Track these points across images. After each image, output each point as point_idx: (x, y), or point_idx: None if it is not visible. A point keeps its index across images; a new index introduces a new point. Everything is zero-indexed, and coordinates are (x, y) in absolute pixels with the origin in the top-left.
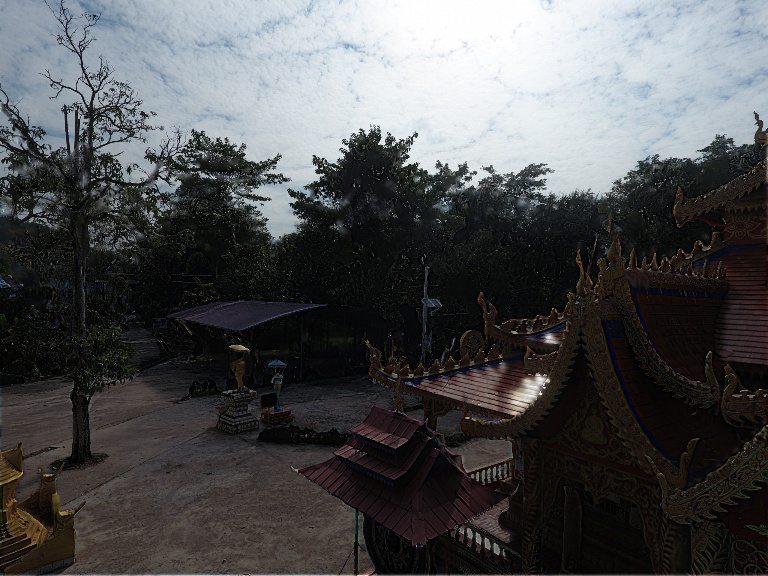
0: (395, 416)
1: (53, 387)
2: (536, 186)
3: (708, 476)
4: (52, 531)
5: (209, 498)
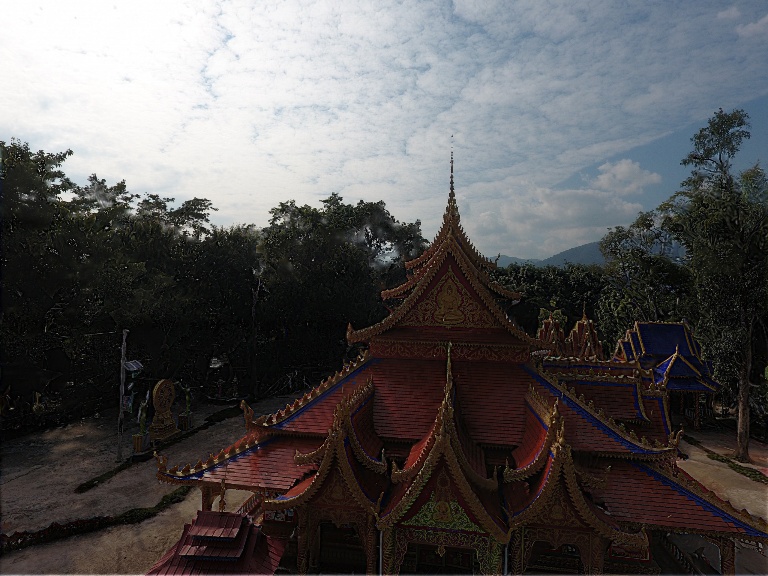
0: (222, 515)
1: None
2: (199, 218)
3: (392, 511)
4: None
5: None
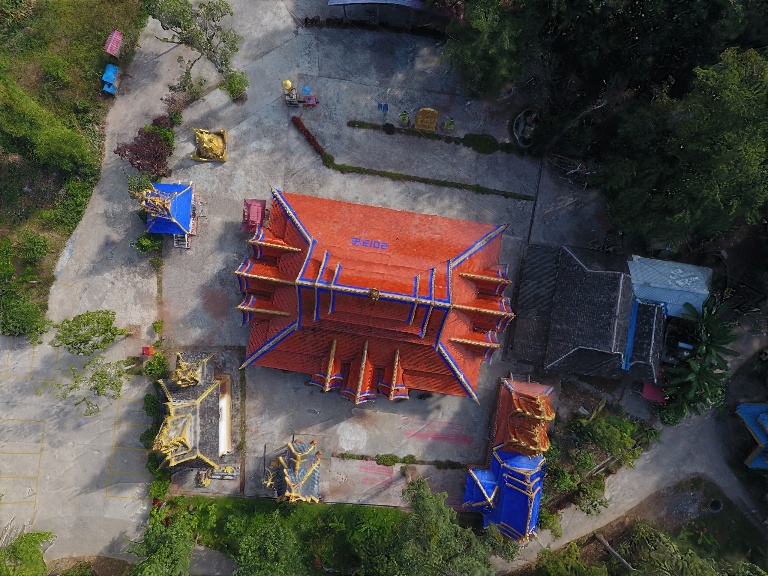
0: None
1: None
2: None
3: None
4: (224, 146)
5: (258, 153)
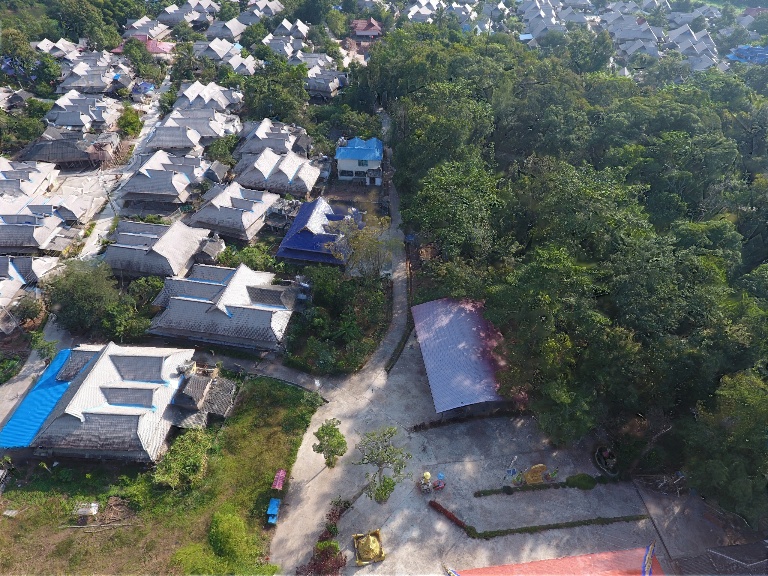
0: None
1: (365, 388)
2: None
3: None
4: None
5: (410, 542)
